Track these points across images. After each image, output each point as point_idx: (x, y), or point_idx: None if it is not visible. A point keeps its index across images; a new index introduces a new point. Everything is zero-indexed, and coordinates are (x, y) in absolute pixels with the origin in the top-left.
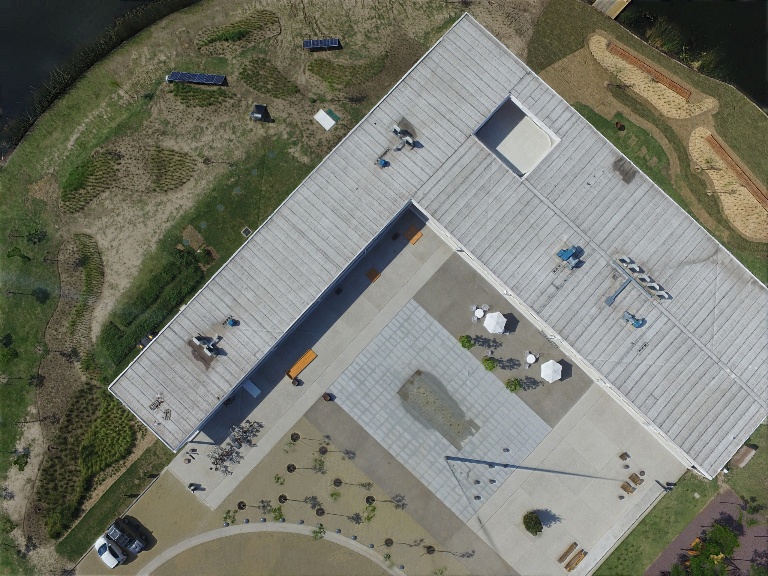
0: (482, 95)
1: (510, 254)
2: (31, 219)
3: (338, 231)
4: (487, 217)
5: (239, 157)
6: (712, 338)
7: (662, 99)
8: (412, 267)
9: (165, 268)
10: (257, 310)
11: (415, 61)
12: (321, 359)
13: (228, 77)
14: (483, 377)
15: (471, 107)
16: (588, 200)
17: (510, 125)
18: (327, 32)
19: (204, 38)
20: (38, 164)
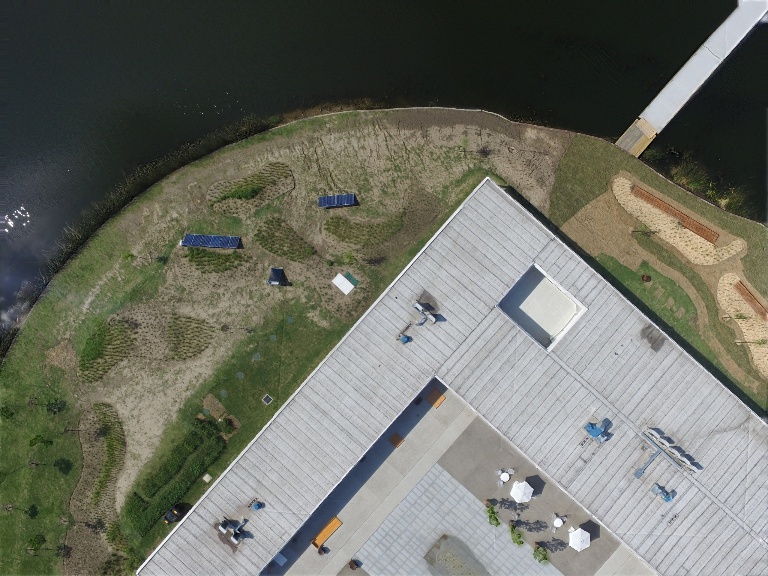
0: (505, 264)
1: (537, 428)
2: (50, 387)
3: (361, 410)
4: (513, 391)
5: (257, 322)
6: (744, 507)
7: (689, 245)
8: (436, 431)
9: (187, 439)
10: (282, 492)
11: (434, 218)
12: (346, 526)
13: (243, 238)
14: (510, 540)
15: (494, 277)
16: (616, 370)
17: (533, 282)
18: (342, 186)
19: (216, 194)
20: (54, 328)
